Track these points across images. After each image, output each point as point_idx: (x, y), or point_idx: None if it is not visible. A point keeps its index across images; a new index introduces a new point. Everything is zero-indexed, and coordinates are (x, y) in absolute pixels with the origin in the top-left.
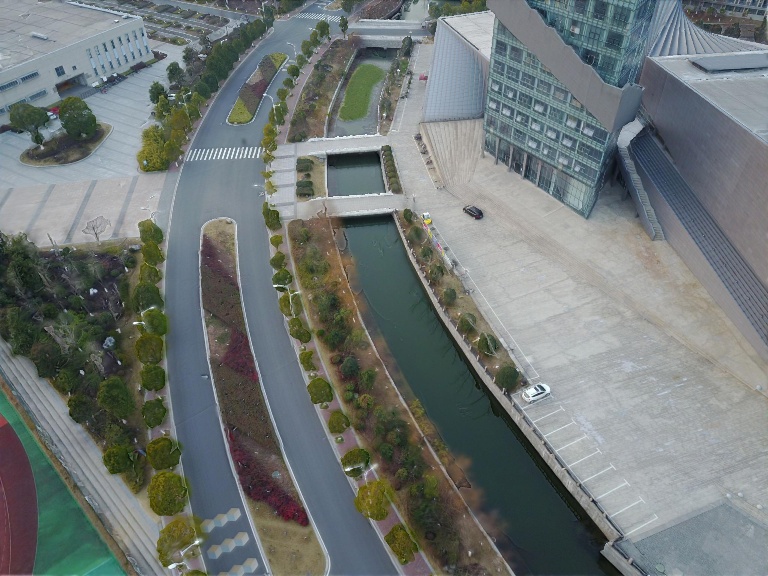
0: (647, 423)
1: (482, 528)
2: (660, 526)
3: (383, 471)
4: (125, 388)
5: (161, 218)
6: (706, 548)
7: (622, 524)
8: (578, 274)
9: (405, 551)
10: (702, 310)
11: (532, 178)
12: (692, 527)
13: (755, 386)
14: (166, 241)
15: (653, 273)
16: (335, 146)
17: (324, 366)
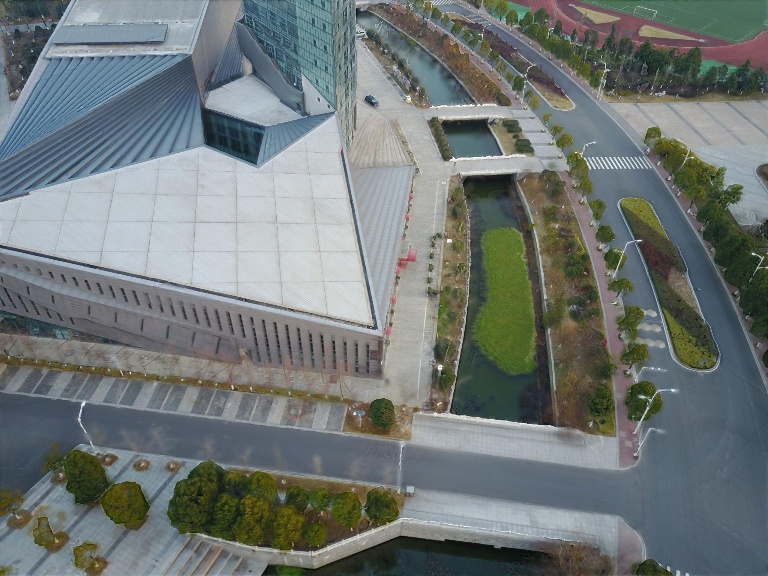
0: None
1: None
2: None
3: None
4: (540, 20)
5: (613, 112)
6: None
7: None
8: None
9: None
10: None
11: None
12: None
13: None
14: (593, 98)
15: None
16: (503, 164)
17: None
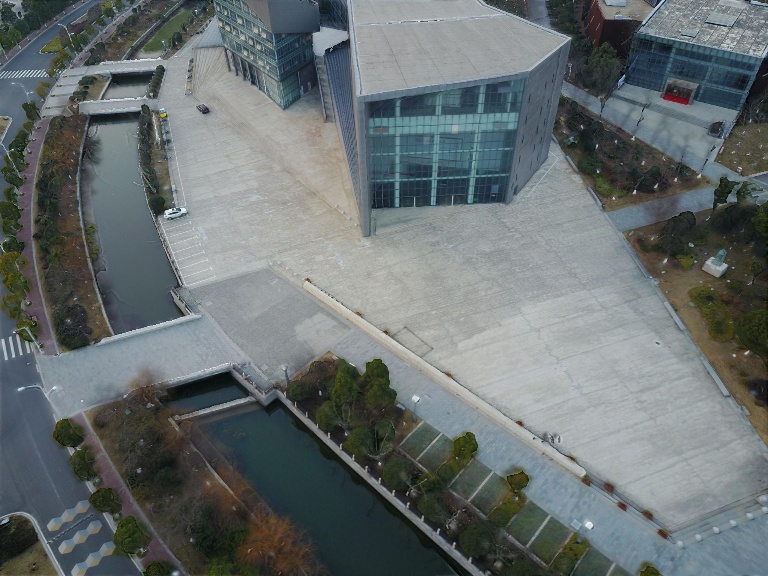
0: (244, 228)
1: (97, 289)
2: (214, 281)
3: (40, 259)
4: None
5: None
6: (237, 291)
7: (188, 280)
8: (256, 145)
9: (12, 286)
10: (330, 164)
11: (256, 83)
12: (235, 281)
13: (335, 206)
14: None
15: (311, 142)
16: (120, 67)
17: (32, 204)
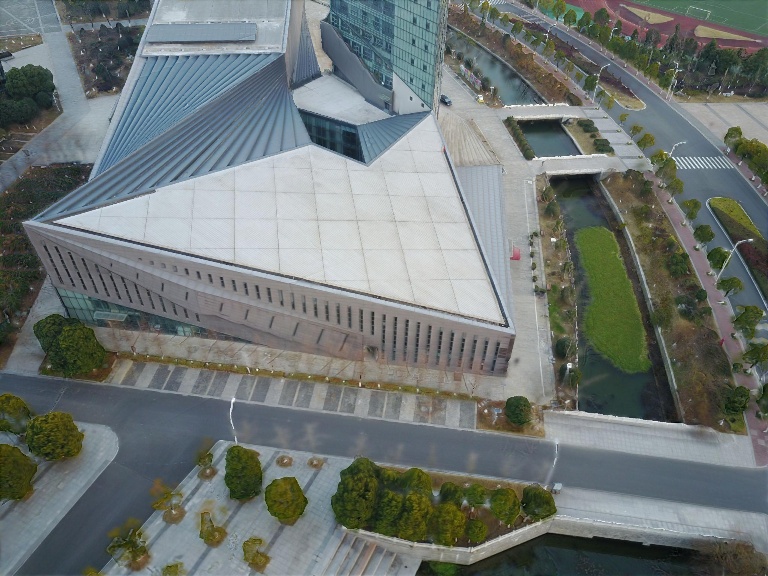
0: None
1: None
2: None
3: None
4: None
5: (685, 112)
6: None
7: None
8: None
9: None
10: None
11: None
12: None
13: None
14: (662, 98)
15: None
16: (585, 164)
17: None
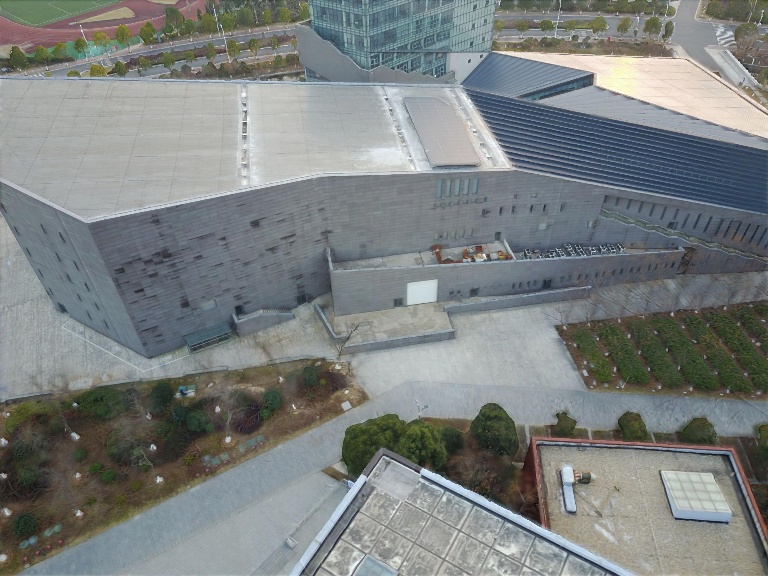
0: None
1: None
2: None
3: None
4: None
5: None
6: None
7: None
8: None
9: None
10: None
11: None
12: None
13: None
14: None
15: None
16: None
17: None
